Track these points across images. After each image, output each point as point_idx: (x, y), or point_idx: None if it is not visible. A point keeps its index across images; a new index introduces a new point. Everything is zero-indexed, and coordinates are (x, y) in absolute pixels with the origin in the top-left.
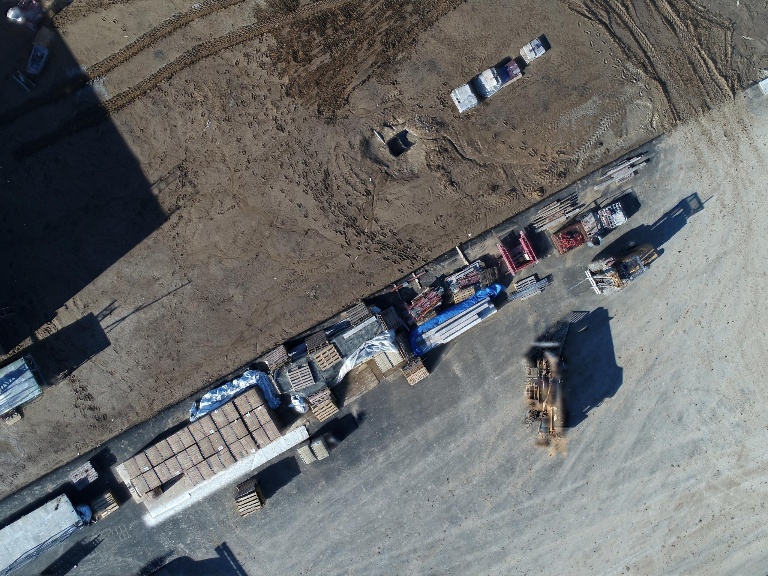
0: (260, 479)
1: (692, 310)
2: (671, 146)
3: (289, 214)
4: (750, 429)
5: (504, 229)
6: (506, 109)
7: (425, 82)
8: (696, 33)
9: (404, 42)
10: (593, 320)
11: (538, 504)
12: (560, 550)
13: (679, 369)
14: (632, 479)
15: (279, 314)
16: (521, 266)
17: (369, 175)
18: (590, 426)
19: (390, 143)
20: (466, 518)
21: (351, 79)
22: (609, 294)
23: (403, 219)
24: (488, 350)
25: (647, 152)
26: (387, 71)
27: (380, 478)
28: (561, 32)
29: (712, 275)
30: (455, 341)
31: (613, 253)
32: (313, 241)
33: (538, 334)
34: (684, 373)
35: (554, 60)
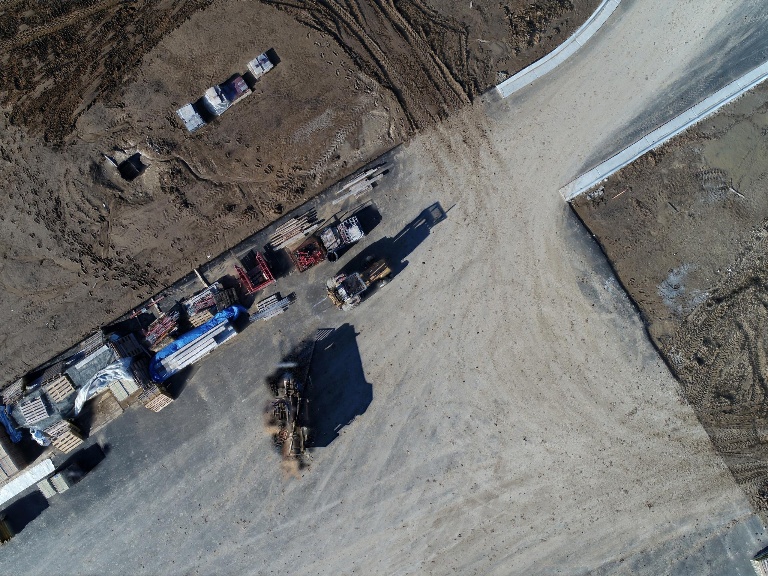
0: (8, 514)
1: (440, 322)
2: (410, 156)
3: (22, 245)
4: (506, 440)
5: (243, 249)
6: (238, 126)
7: (153, 103)
8: (429, 39)
9: (129, 64)
10: (339, 337)
11: (293, 526)
12: (318, 571)
13: (430, 382)
14: (387, 496)
15: (18, 347)
16: (258, 286)
17: (102, 201)
18: (342, 445)
19: (124, 167)
20: (220, 544)
21: (77, 104)
22: (346, 310)
23: (139, 244)
24: (233, 373)
25: (385, 163)
26: (114, 94)
27: (130, 507)
28: (290, 45)
29: (459, 285)
30: (199, 365)
31: (356, 268)
32: (49, 271)
33: (283, 354)
34: (435, 386)
35: (285, 74)
